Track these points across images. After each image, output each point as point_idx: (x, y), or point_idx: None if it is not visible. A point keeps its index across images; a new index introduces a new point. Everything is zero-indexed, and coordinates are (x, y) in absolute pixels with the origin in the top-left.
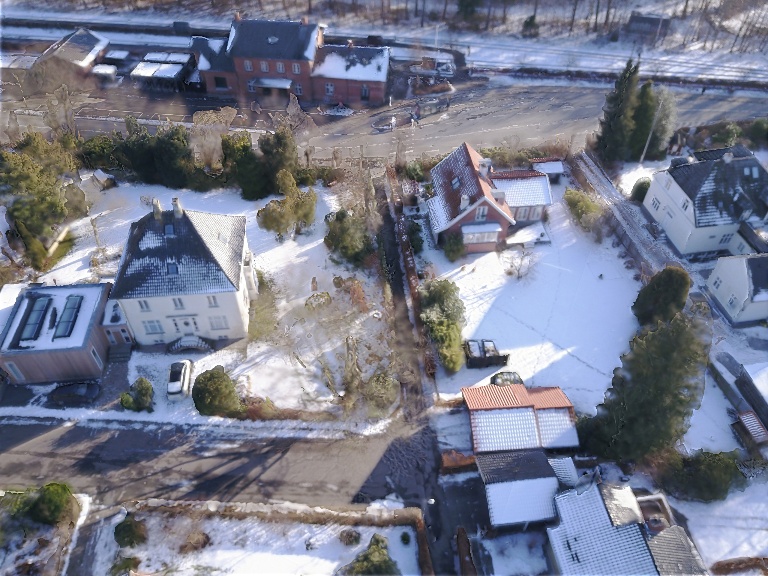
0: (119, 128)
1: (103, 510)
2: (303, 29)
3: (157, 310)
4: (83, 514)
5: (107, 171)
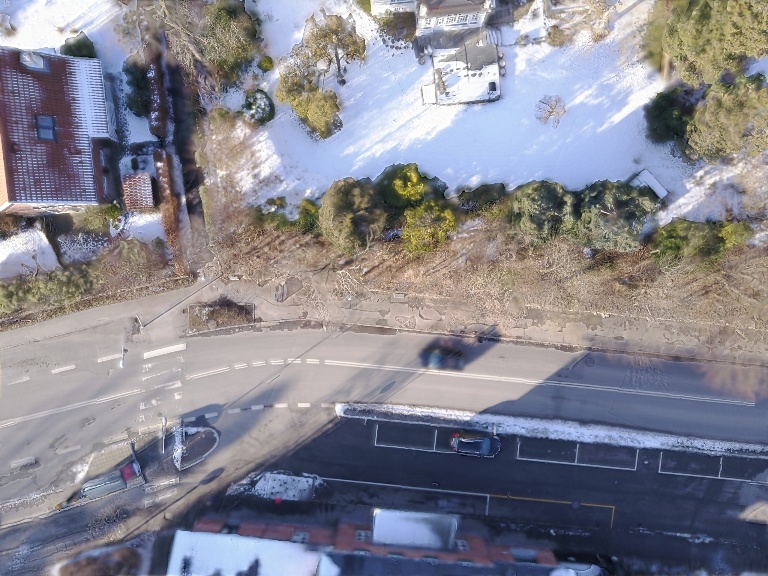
0: (686, 414)
1: None
2: None
3: None
4: None
5: None
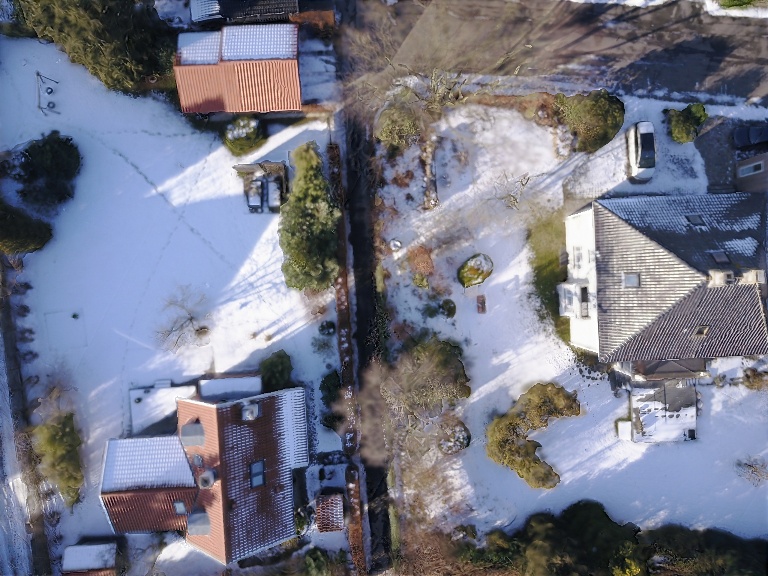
0: None
1: None
2: None
3: None
4: None
5: None
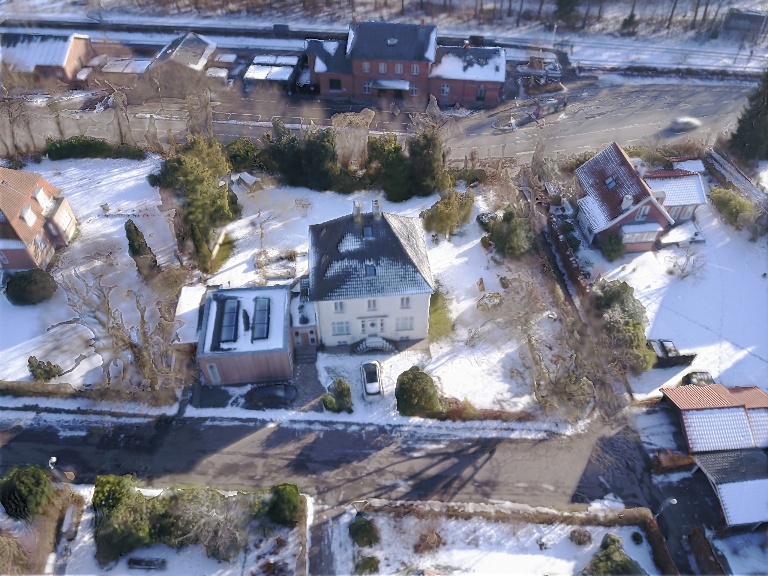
0: (242, 131)
1: (328, 510)
2: (421, 30)
3: (350, 311)
4: (310, 514)
5: (253, 174)
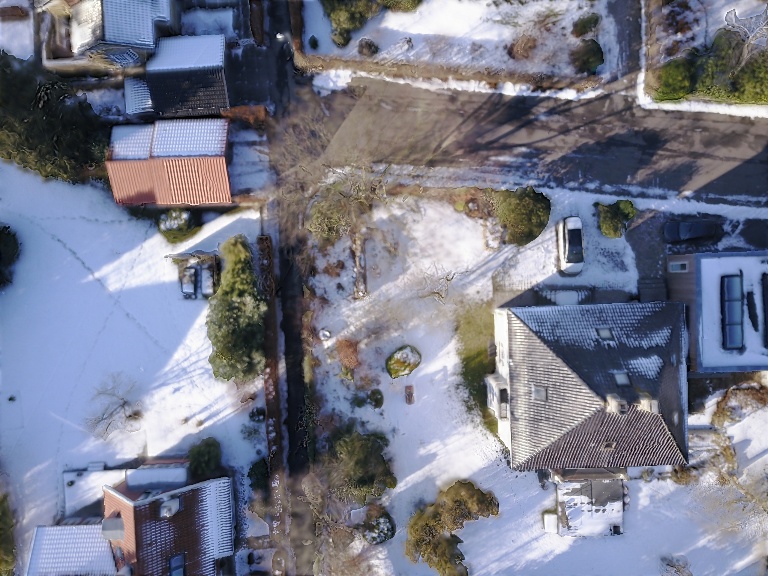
0: None
1: (622, 89)
2: None
3: None
4: (641, 85)
5: None
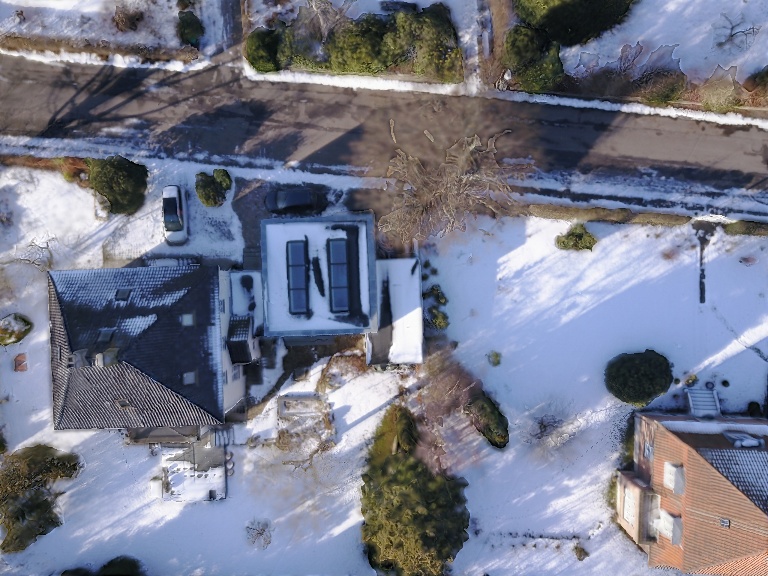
0: None
1: (228, 61)
2: None
3: None
4: None
5: None
